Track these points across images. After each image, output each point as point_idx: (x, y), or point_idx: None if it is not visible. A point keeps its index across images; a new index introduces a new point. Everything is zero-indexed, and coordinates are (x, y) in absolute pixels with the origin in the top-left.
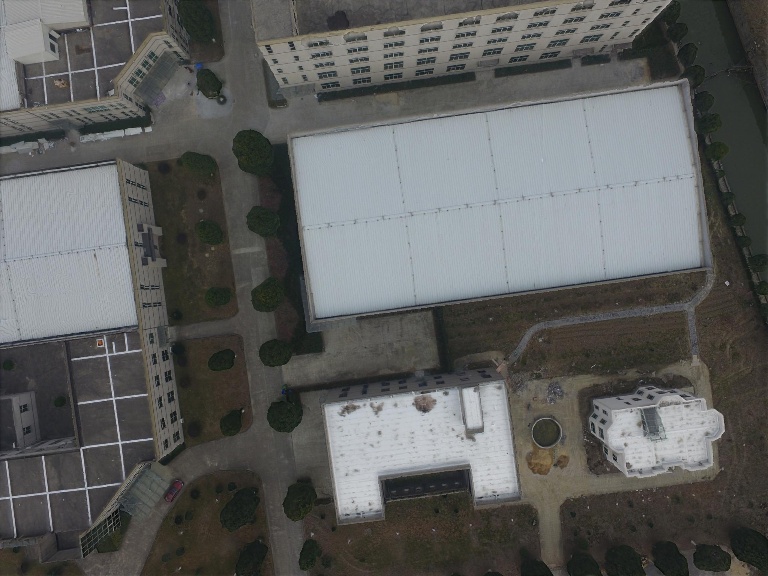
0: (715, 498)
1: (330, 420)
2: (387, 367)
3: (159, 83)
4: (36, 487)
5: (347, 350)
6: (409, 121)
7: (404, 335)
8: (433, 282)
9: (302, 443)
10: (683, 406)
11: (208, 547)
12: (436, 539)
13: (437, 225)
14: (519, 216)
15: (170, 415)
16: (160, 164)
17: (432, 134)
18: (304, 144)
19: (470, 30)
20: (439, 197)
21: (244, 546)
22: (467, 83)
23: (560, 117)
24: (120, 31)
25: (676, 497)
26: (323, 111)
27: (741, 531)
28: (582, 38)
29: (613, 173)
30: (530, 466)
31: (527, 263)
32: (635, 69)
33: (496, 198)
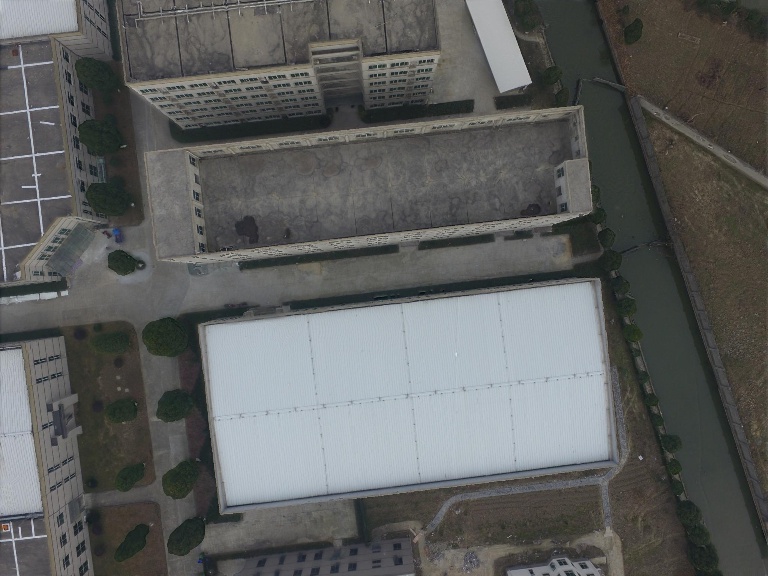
0: None
1: None
2: (305, 536)
3: (73, 255)
4: None
5: (265, 519)
6: (324, 311)
7: (323, 505)
8: (345, 472)
9: None
10: None
11: None
12: None
13: (350, 417)
14: (431, 410)
15: None
16: (76, 329)
17: (349, 320)
18: (218, 329)
19: None
20: (352, 390)
21: None
22: (390, 255)
23: (475, 310)
24: (28, 210)
25: None
26: (245, 279)
27: None
28: None
29: (525, 369)
30: None
31: (439, 455)
32: (557, 245)
33: (409, 392)
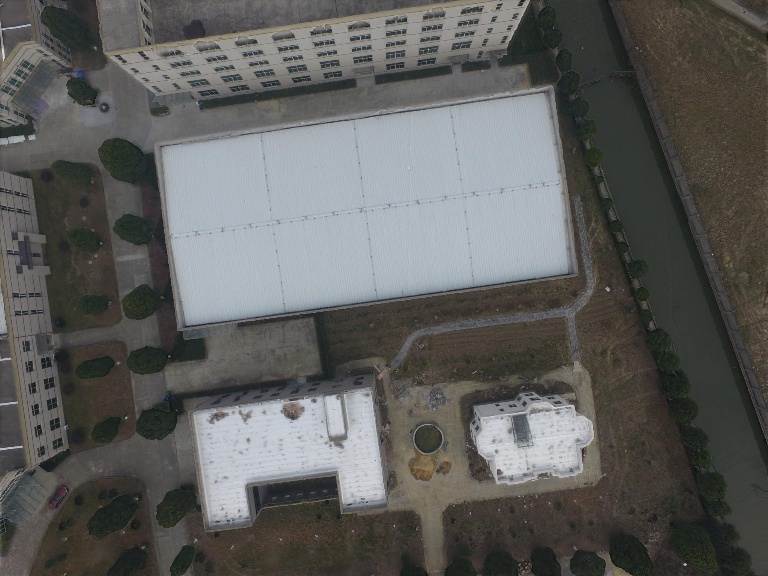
0: (597, 504)
1: (199, 427)
2: (270, 374)
3: (36, 91)
4: None
5: (230, 357)
6: (277, 129)
7: (286, 342)
8: (302, 290)
9: (186, 449)
10: (554, 413)
11: (92, 553)
12: (319, 545)
13: (304, 233)
14: (386, 224)
15: (50, 422)
16: (43, 172)
17: (303, 142)
18: (175, 152)
19: (327, 38)
20: (306, 205)
21: (122, 552)
22: (348, 90)
23: (427, 124)
24: None
25: (558, 503)
26: (205, 118)
27: (618, 537)
28: (452, 45)
29: (479, 180)
30: (412, 472)
31: (395, 270)
32: (516, 75)
33: (363, 206)
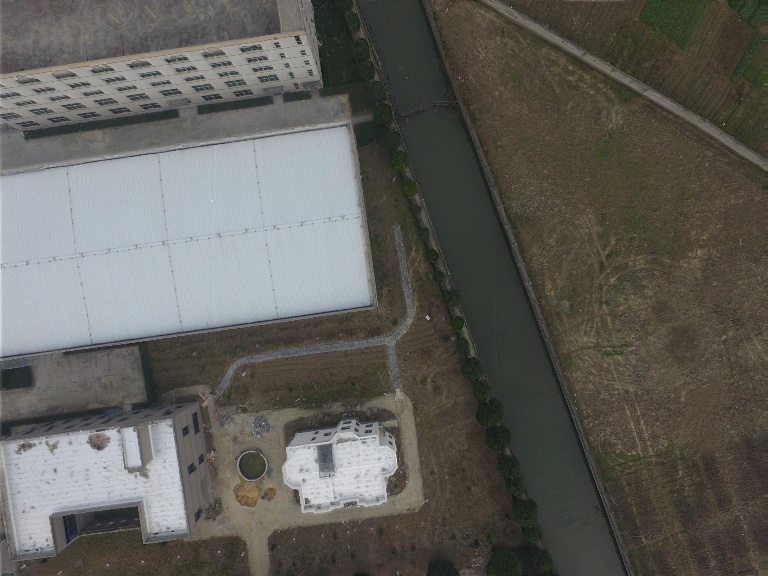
0: (419, 529)
1: (7, 458)
2: (96, 401)
3: None
4: None
5: (57, 385)
6: (83, 162)
7: (112, 370)
8: (107, 322)
9: None
10: (360, 442)
11: None
12: (146, 570)
13: (108, 266)
14: (188, 256)
15: None
16: None
17: (113, 174)
18: None
19: (115, 75)
20: (109, 238)
21: None
22: (171, 120)
23: (231, 158)
24: None
25: (380, 529)
26: (31, 148)
27: (433, 563)
28: (258, 78)
29: (280, 213)
30: (237, 498)
31: (199, 302)
32: (337, 105)
33: (165, 239)
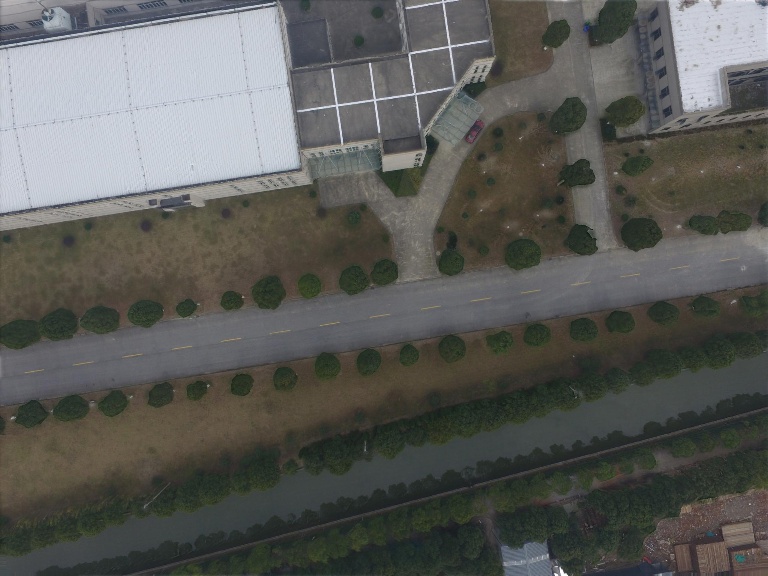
0: None
1: None
2: None
3: None
4: (363, 94)
5: None
6: None
7: None
8: None
9: (604, 82)
10: None
11: (511, 187)
12: (740, 177)
13: None
14: None
15: None
16: None
17: None
18: None
19: None
20: None
21: (563, 167)
22: None
23: None
24: None
25: None
26: None
27: None
28: None
29: None
30: None
31: None
32: None
33: None
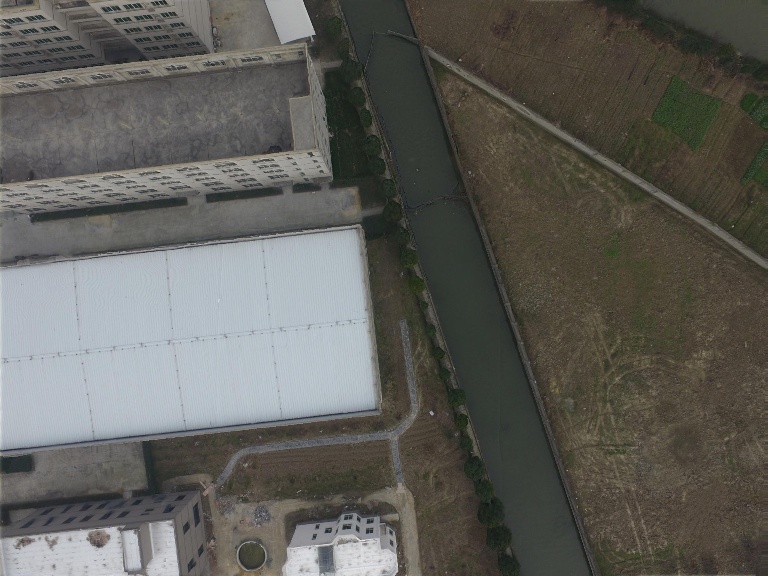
0: None
1: (6, 552)
2: (96, 487)
3: None
4: None
5: (57, 469)
6: (90, 257)
7: (113, 456)
8: (110, 418)
9: None
10: (361, 544)
11: None
12: None
13: (113, 363)
14: (194, 356)
15: None
16: None
17: (120, 268)
18: None
19: None
20: (115, 335)
21: None
22: (179, 207)
23: (239, 257)
24: None
25: None
26: (37, 231)
27: None
28: None
29: (287, 316)
30: None
31: (203, 402)
32: (346, 197)
33: (171, 338)
